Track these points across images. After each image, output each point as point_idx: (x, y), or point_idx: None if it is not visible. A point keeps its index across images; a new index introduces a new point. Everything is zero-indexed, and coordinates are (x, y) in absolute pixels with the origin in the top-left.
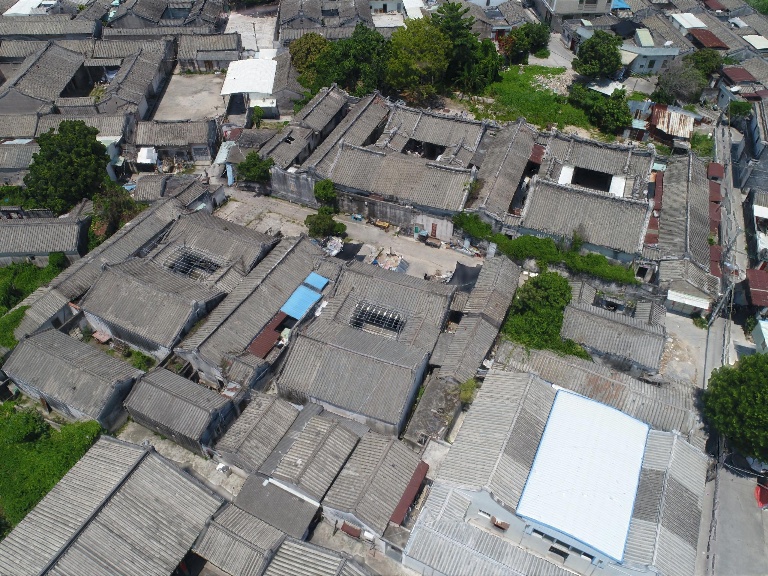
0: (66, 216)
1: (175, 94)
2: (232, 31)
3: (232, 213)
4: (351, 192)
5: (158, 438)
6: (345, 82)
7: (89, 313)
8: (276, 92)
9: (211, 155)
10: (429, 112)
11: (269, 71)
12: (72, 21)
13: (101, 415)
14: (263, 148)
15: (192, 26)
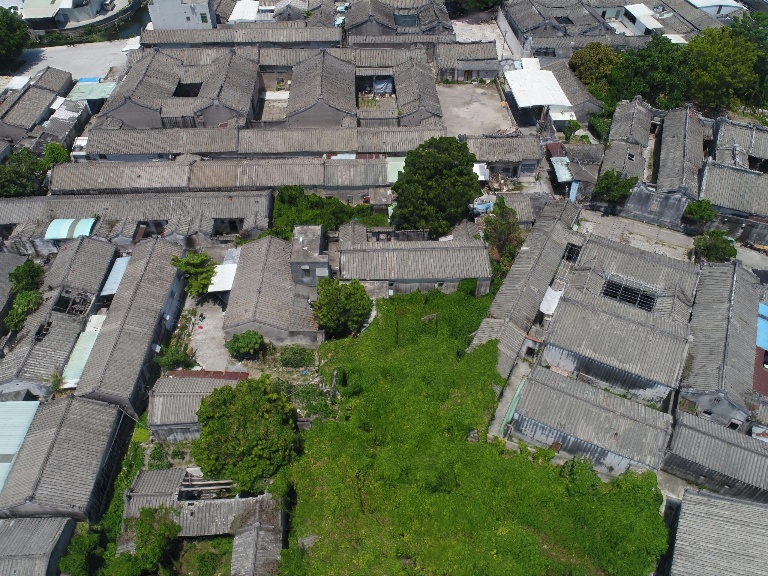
0: (450, 238)
1: (447, 105)
2: (458, 38)
3: None
4: (726, 213)
5: (694, 488)
6: (646, 94)
7: (556, 347)
8: (577, 105)
9: (537, 171)
10: (764, 127)
11: (552, 82)
12: (317, 28)
13: None
14: (605, 165)
15: (430, 33)
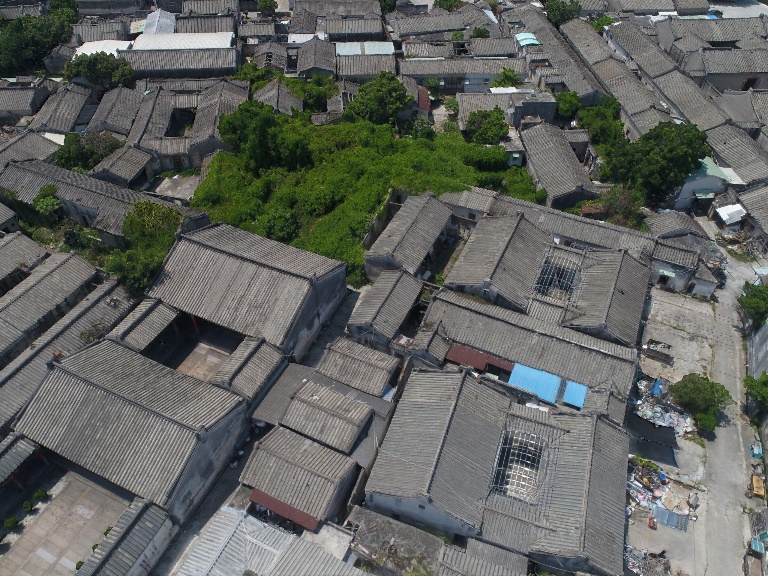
0: (597, 183)
1: None
2: None
3: (688, 310)
4: None
5: None
6: None
7: None
8: None
9: None
10: None
11: None
12: None
13: (368, 259)
14: None
15: None
